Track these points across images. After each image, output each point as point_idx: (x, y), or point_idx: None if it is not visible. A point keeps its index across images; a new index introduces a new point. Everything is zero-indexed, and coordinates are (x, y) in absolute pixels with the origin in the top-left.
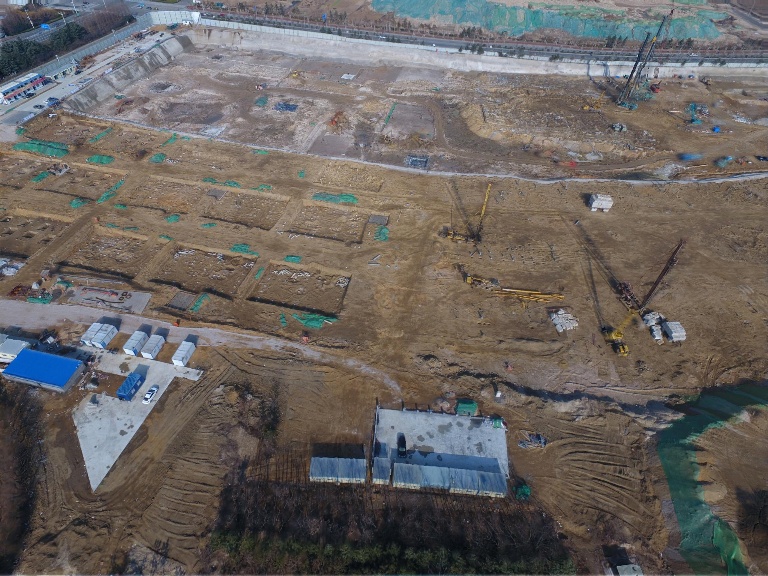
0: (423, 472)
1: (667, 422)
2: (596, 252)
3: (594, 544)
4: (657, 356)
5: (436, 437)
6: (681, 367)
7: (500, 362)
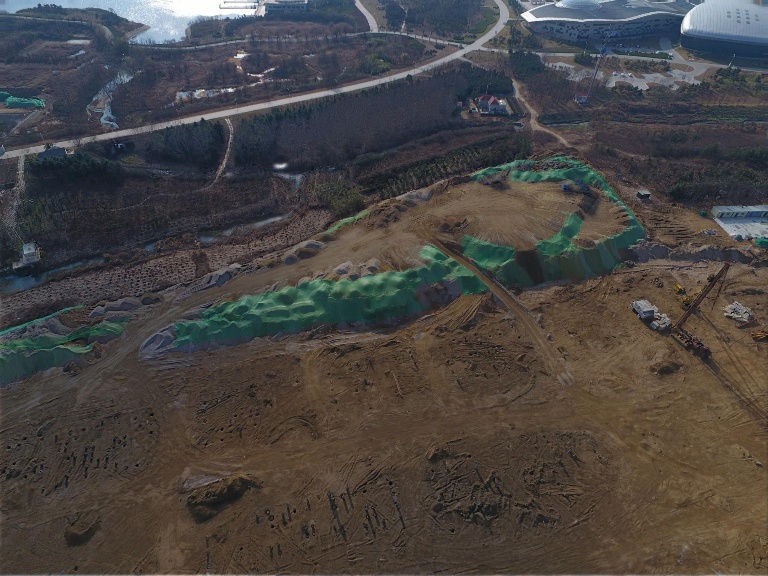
0: (760, 209)
1: (640, 242)
2: (754, 414)
3: (659, 204)
4: (648, 293)
5: (765, 229)
6: (629, 285)
7: (761, 276)
